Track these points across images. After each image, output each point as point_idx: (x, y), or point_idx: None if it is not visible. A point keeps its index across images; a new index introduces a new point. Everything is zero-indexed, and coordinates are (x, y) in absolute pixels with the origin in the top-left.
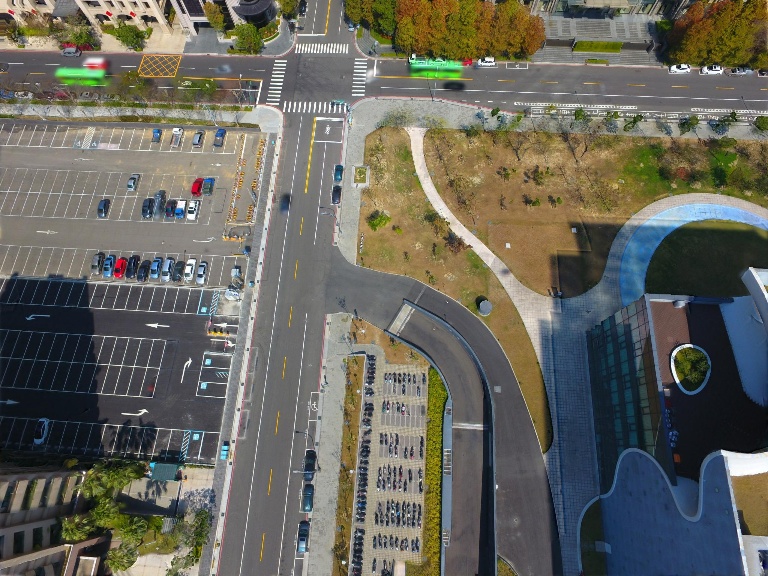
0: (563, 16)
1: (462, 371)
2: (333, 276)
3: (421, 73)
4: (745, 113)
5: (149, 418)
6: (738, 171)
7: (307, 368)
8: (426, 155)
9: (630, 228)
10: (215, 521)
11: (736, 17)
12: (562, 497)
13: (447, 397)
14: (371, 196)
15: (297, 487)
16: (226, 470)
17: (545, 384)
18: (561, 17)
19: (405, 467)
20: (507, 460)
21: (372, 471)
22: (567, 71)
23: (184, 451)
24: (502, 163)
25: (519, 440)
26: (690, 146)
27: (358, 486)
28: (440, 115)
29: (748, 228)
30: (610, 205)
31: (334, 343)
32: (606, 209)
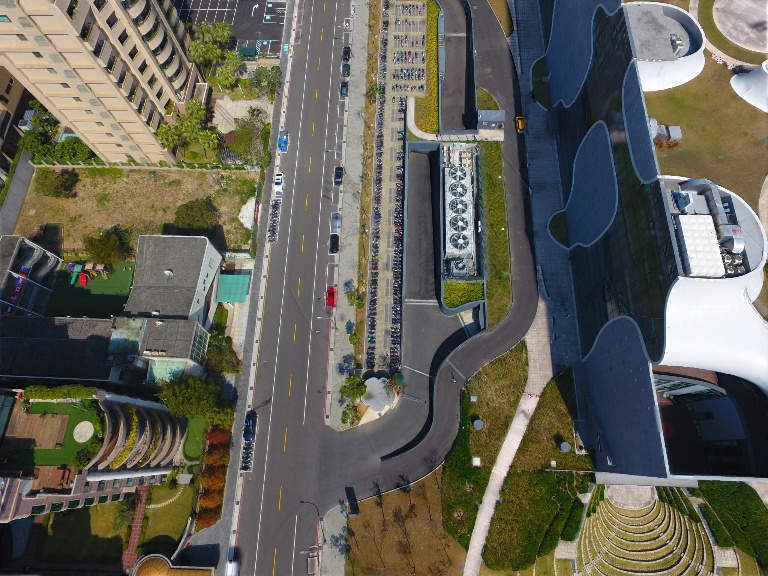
0: None
1: (450, 6)
2: None
3: None
4: None
5: (231, 35)
6: None
7: (341, 6)
8: None
9: None
10: (282, 85)
11: None
12: (520, 57)
13: (440, 10)
14: None
15: (338, 66)
16: (288, 60)
17: (508, 4)
18: None
19: (412, 52)
20: (482, 42)
21: (390, 55)
22: None
23: (258, 50)
24: None
25: (490, 32)
26: None
27: (380, 61)
28: None
29: None
30: None
31: None
32: None
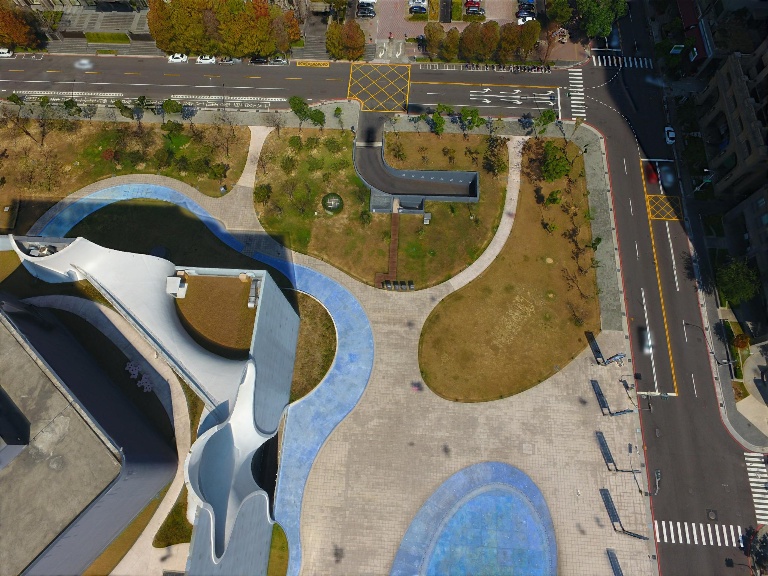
0: (95, 10)
1: None
2: None
3: None
4: (219, 99)
5: None
6: (161, 152)
7: None
8: None
9: (60, 207)
10: None
11: (188, 8)
12: None
13: None
14: None
15: None
16: None
17: None
18: (93, 11)
19: None
20: None
21: None
22: (75, 61)
23: None
24: None
25: None
26: (154, 130)
27: None
28: None
29: (169, 206)
30: (53, 186)
31: None
32: (47, 189)
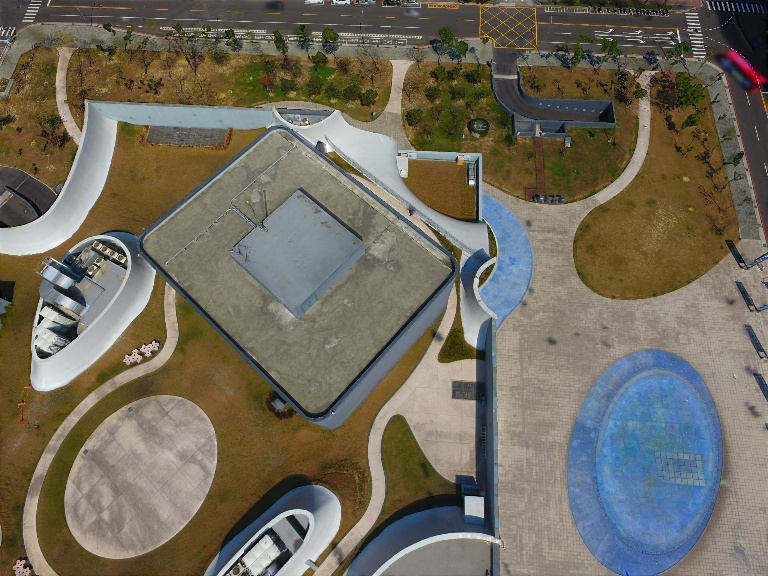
0: None
1: None
2: None
3: (89, 3)
4: (358, 36)
5: None
6: (316, 79)
7: None
8: (69, 70)
9: None
10: None
11: None
12: None
13: None
14: (8, 103)
15: None
16: None
17: None
18: None
19: None
20: None
21: None
22: (216, 1)
23: None
24: (131, 76)
25: None
26: (299, 63)
27: None
28: (92, 37)
29: None
30: None
31: None
32: None
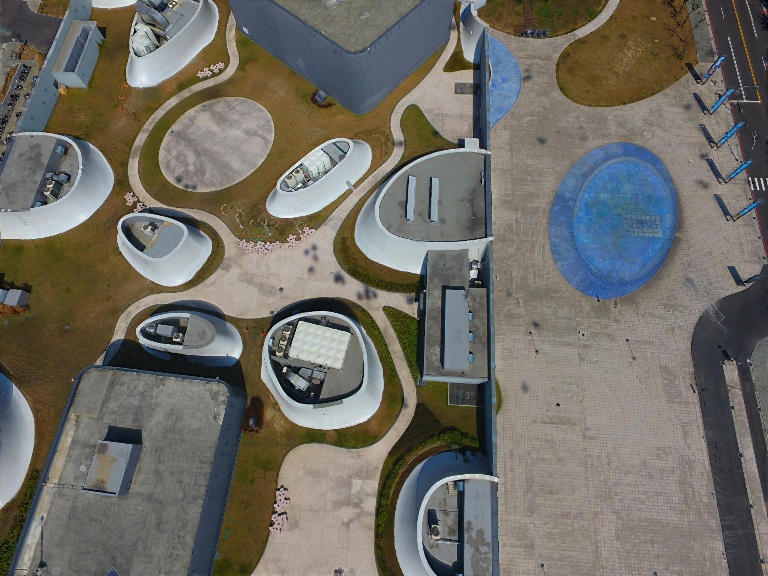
0: None
1: None
2: (17, 19)
3: None
4: None
5: None
6: None
7: None
8: None
9: None
10: None
11: None
12: None
13: None
14: None
15: None
16: None
17: None
18: None
19: None
20: None
21: (6, 134)
22: None
23: None
24: None
25: None
26: None
27: None
28: None
29: None
30: None
31: (3, 60)
32: None
